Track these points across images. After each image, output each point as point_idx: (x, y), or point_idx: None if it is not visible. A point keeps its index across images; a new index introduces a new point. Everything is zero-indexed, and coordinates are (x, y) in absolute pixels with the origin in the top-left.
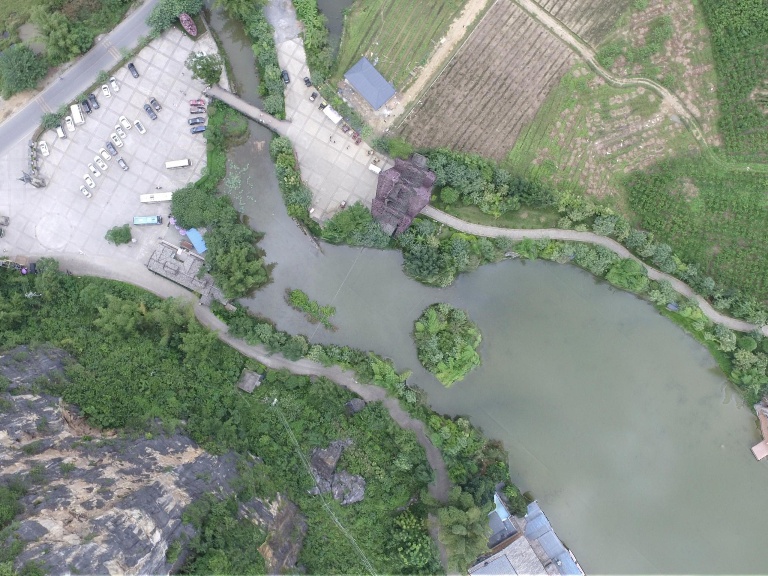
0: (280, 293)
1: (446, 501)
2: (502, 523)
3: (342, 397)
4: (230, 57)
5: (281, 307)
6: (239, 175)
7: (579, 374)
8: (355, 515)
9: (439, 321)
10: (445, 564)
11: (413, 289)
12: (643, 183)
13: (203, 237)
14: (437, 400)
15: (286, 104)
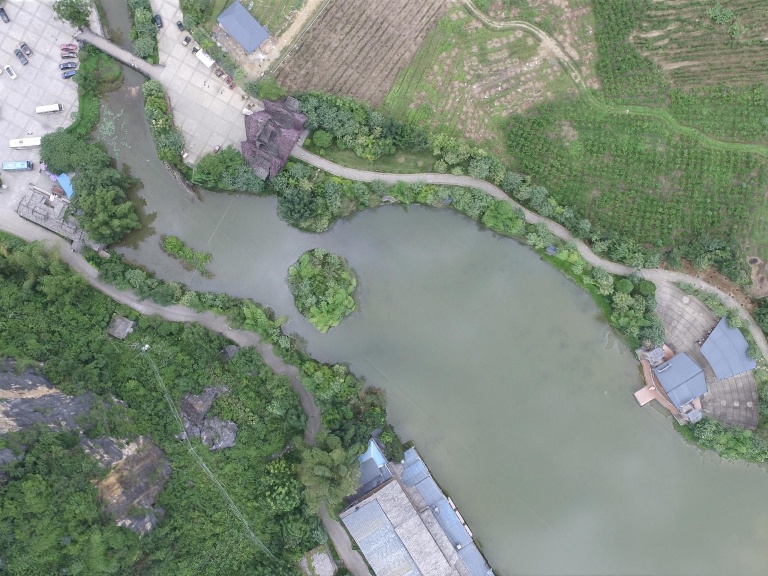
0: (155, 240)
1: (313, 444)
2: (378, 469)
3: (213, 342)
4: (102, 1)
5: (157, 254)
6: (113, 121)
7: (459, 320)
8: (225, 460)
9: (312, 265)
10: (321, 511)
11: (290, 235)
12: (521, 126)
13: (70, 181)
14: (316, 348)
15: (159, 49)
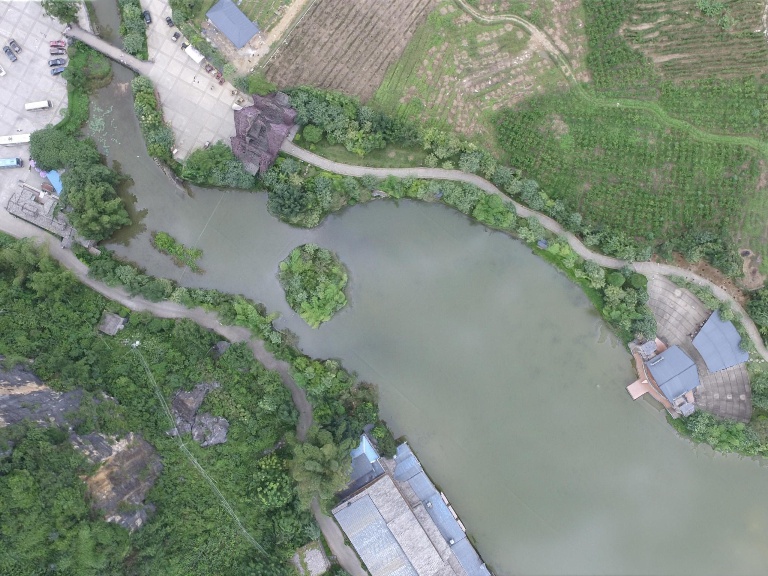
0: (146, 236)
1: (304, 439)
2: (370, 465)
3: (204, 338)
4: None
5: (147, 250)
6: (103, 117)
7: (451, 315)
8: (216, 457)
9: (303, 260)
10: (313, 507)
11: (281, 231)
12: (511, 120)
13: (60, 177)
14: (308, 343)
15: (148, 45)
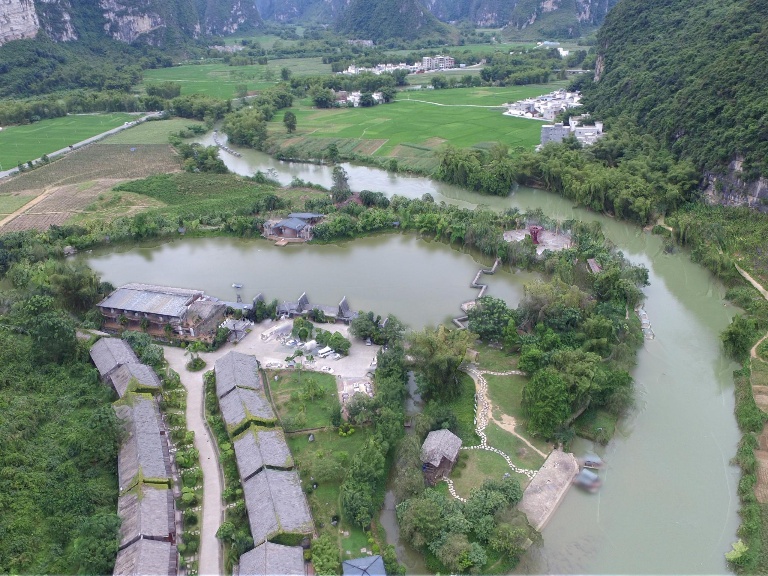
0: None
1: None
2: None
3: None
4: None
5: None
6: None
7: None
8: None
9: None
10: None
11: None
12: None
13: None
14: None
15: None
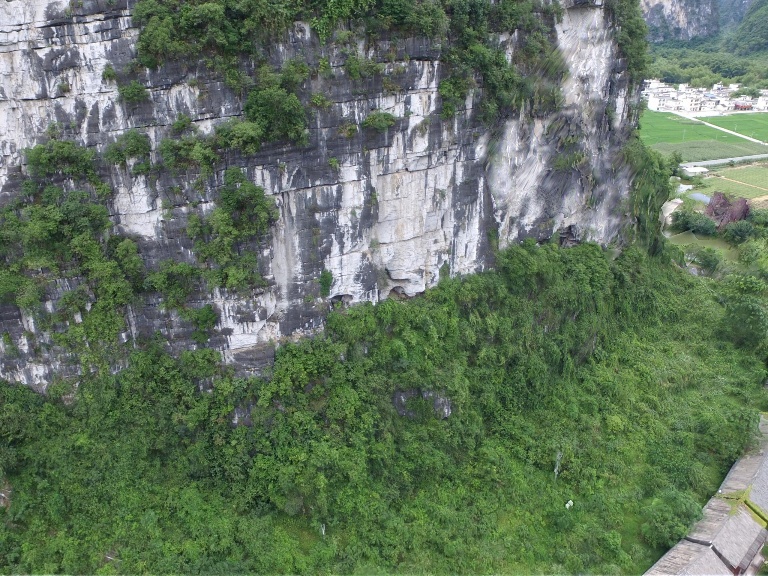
0: None
1: None
2: None
3: None
4: None
5: None
6: None
7: None
8: None
9: None
10: None
11: None
12: None
13: None
14: None
15: None
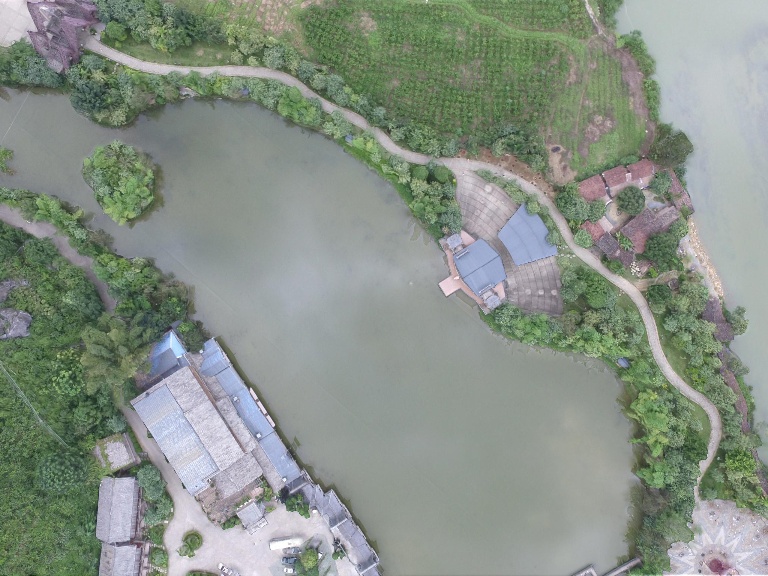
0: None
1: None
2: (175, 359)
3: (6, 233)
4: None
5: None
6: None
7: (262, 213)
8: (15, 349)
9: (107, 156)
10: None
11: (92, 131)
12: (318, 17)
13: None
14: (121, 243)
15: None
